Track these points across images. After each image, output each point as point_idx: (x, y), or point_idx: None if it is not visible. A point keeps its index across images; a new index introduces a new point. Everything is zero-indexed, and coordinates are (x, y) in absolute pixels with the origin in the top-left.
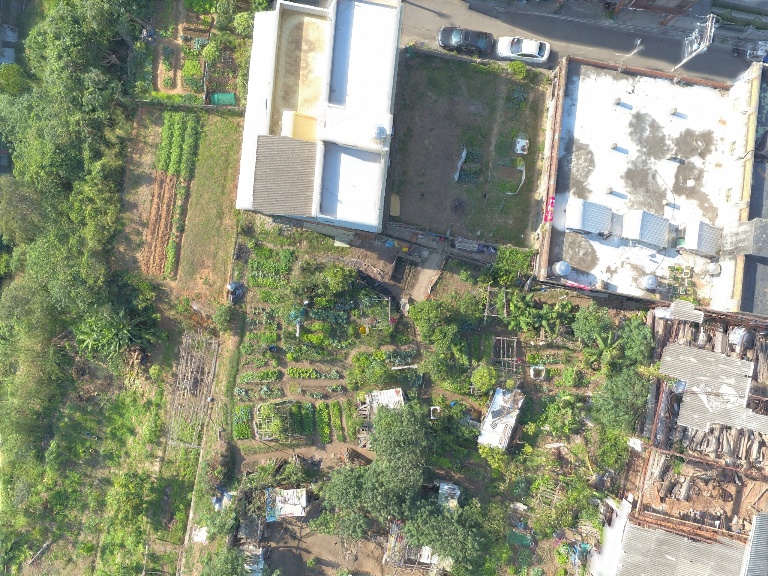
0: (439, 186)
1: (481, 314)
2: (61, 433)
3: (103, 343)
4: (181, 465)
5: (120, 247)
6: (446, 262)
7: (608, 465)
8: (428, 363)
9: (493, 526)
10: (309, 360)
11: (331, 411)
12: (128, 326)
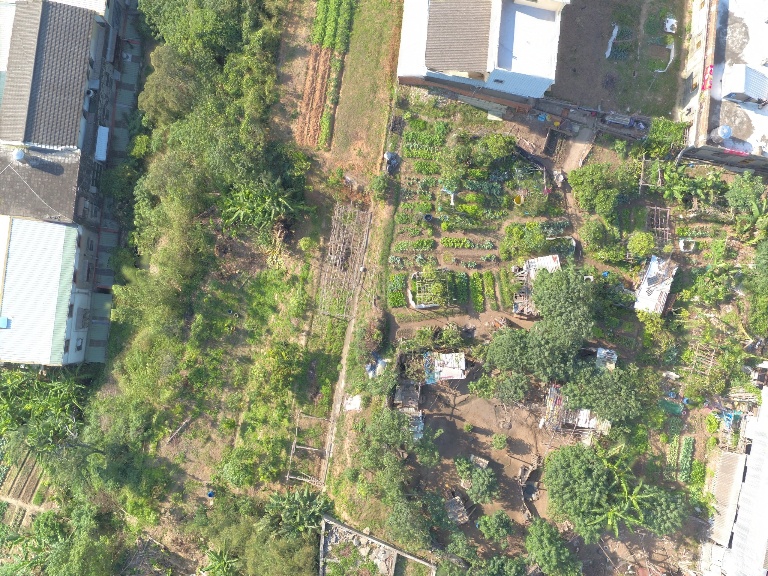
0: (590, 63)
1: (636, 183)
2: (202, 310)
3: (256, 212)
4: (327, 339)
5: (274, 118)
6: (597, 137)
7: (760, 334)
8: (591, 225)
9: (650, 391)
10: (463, 229)
11: (485, 280)
12: (283, 194)
